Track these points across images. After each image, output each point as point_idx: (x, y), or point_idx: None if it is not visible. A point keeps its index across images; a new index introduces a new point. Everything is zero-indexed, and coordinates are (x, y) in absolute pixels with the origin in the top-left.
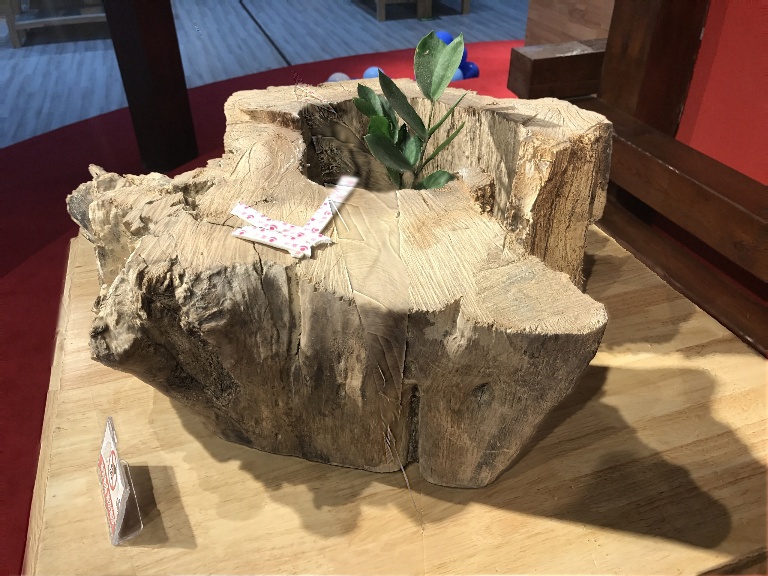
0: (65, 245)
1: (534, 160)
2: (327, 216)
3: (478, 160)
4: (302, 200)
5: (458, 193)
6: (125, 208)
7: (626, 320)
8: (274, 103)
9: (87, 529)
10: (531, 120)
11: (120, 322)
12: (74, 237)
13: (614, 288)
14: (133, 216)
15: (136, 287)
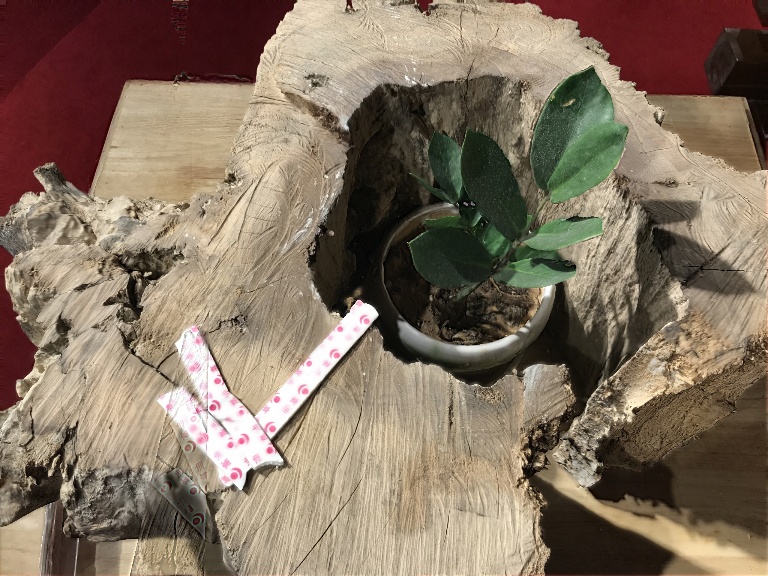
0: (114, 95)
1: (667, 364)
2: (299, 398)
3: (608, 252)
4: (283, 337)
5: (506, 414)
6: (46, 292)
7: (741, 477)
8: (332, 65)
9: (25, 565)
10: (706, 266)
11: (5, 482)
12: (128, 80)
13: (754, 409)
14: (50, 315)
15: (24, 449)
